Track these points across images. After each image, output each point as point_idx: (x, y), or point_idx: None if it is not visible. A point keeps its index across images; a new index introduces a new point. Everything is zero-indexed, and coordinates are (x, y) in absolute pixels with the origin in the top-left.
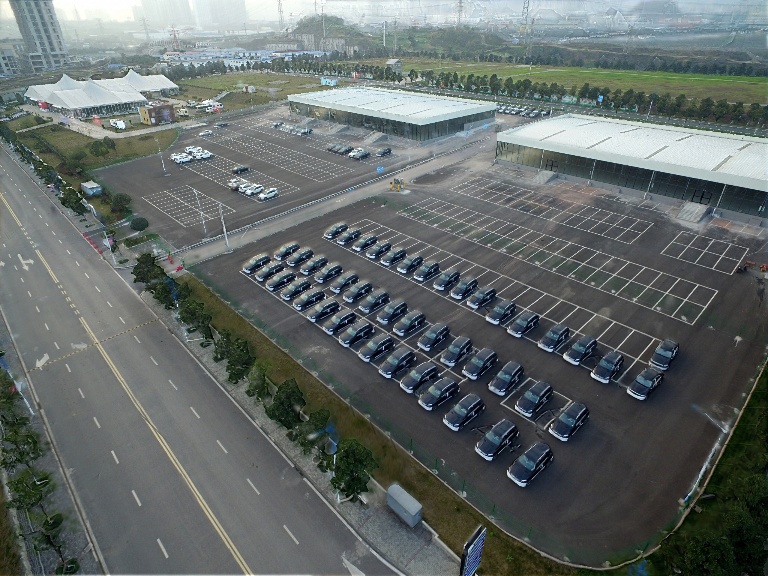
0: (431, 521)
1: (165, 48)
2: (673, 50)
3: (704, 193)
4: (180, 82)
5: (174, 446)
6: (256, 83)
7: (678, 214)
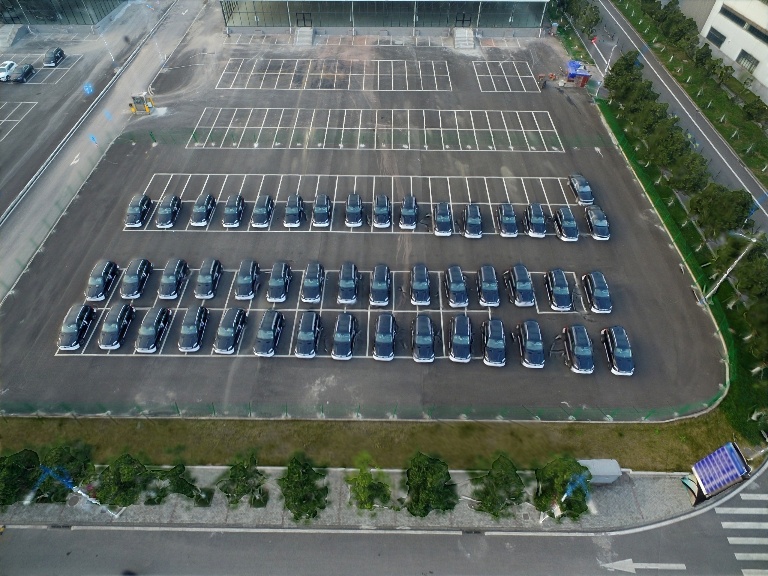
0: None
1: None
2: None
3: (464, 15)
4: None
5: None
6: None
7: (455, 44)
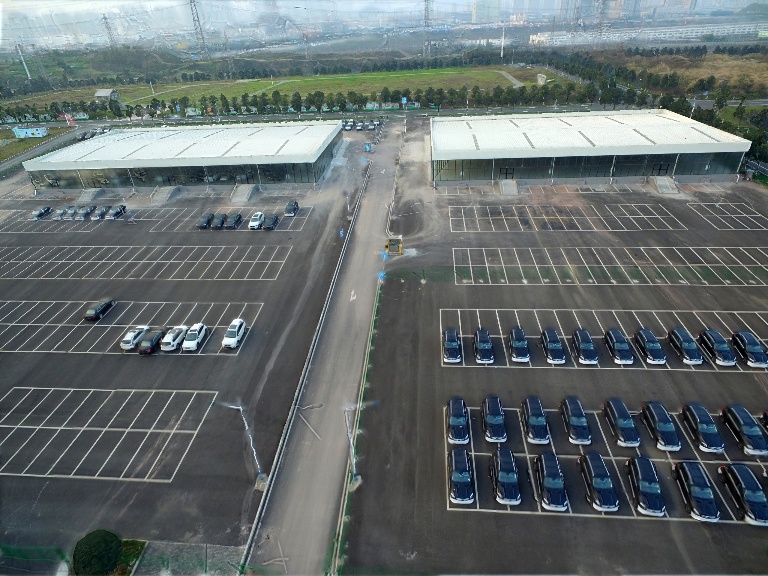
0: None
1: None
2: (345, 54)
3: (662, 165)
4: None
5: None
6: None
7: (658, 190)
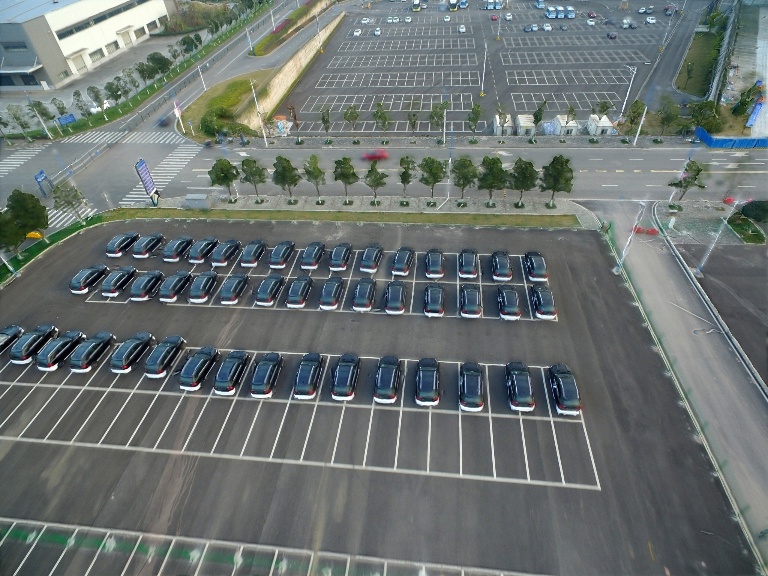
0: None
1: None
2: None
3: None
4: None
5: None
6: None
7: None
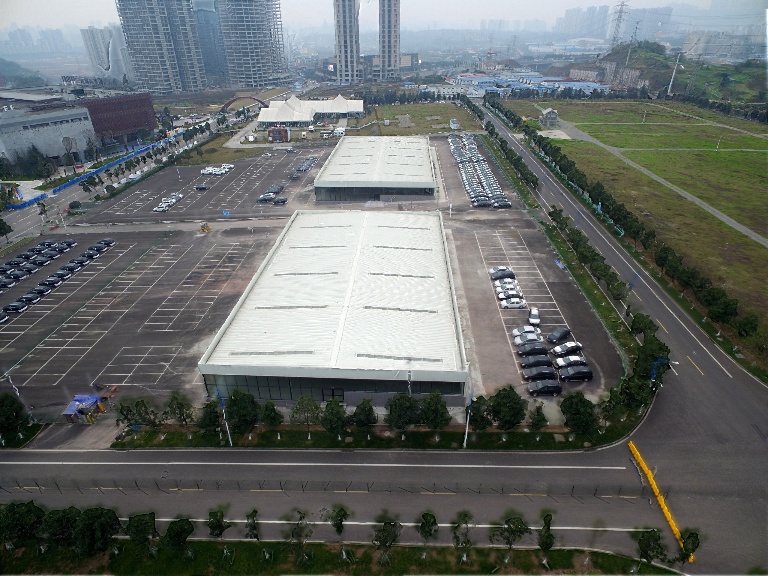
0: None
1: (468, 69)
2: None
3: None
4: (383, 106)
5: None
6: (418, 116)
7: None
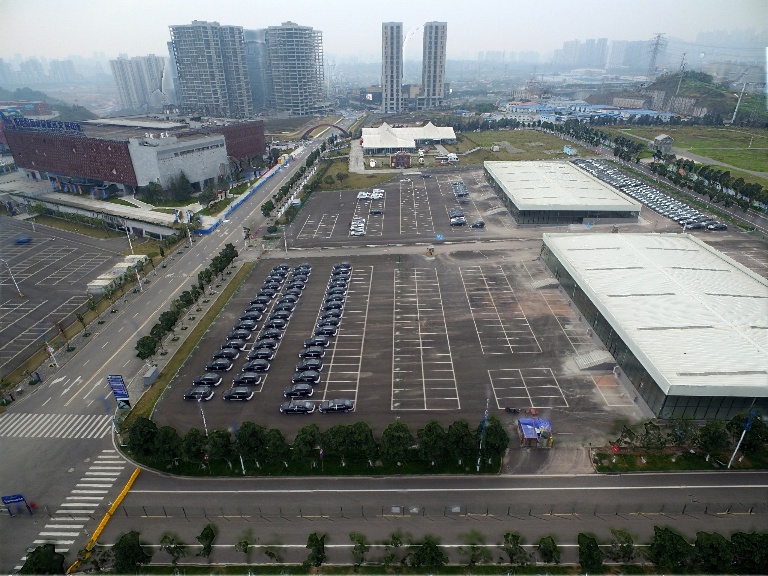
0: (152, 387)
1: (514, 98)
2: None
3: (616, 347)
4: (468, 133)
5: (149, 321)
6: (516, 142)
7: (579, 356)
